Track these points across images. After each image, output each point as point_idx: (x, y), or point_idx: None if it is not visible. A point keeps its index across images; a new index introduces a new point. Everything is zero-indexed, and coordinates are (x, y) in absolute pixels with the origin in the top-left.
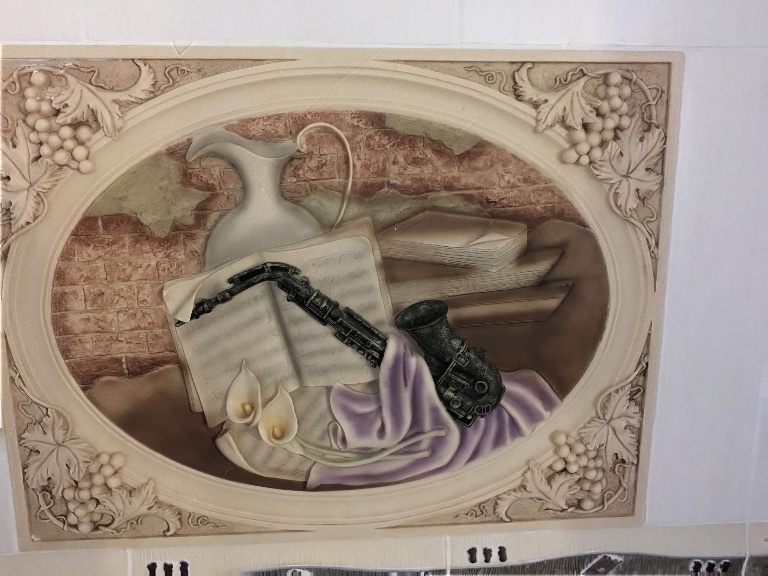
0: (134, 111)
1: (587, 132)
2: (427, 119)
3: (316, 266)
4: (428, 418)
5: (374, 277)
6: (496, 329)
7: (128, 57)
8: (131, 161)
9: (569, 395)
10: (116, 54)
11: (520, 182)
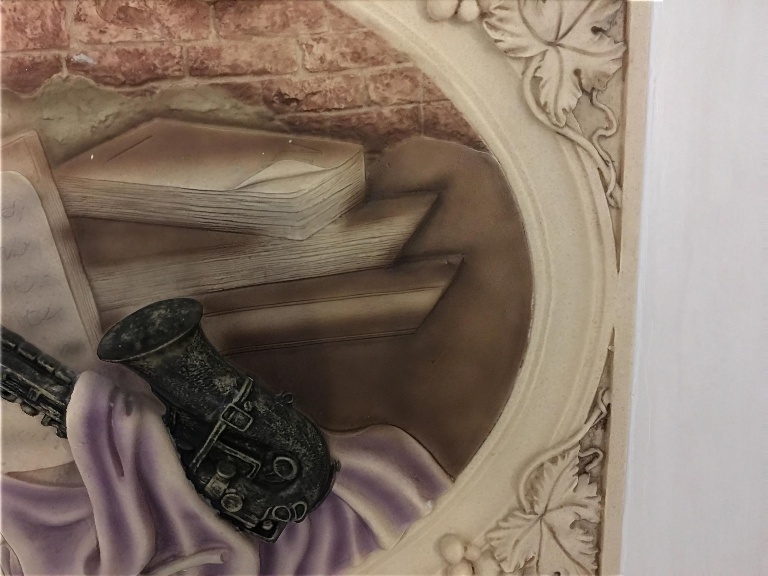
0: None
1: None
2: None
3: None
4: (185, 531)
5: (51, 255)
6: (317, 352)
7: None
8: None
9: (467, 469)
10: None
11: (346, 60)
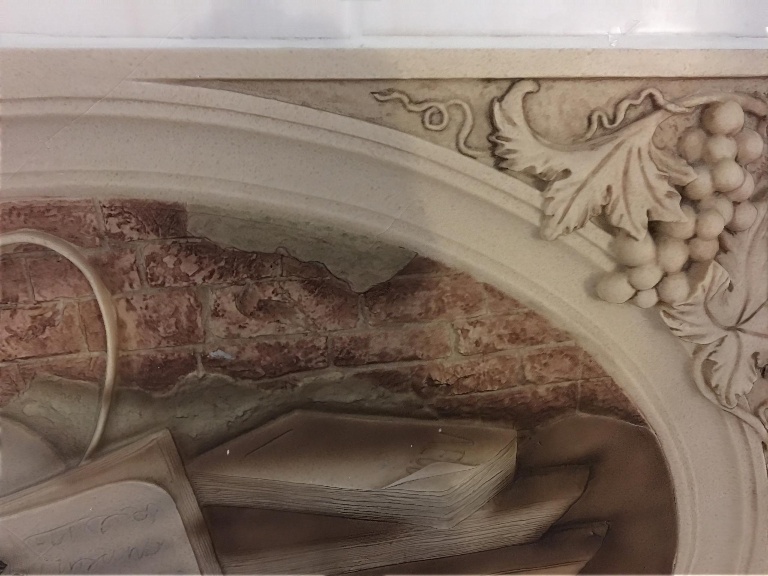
0: None
1: (656, 239)
2: (287, 215)
3: (47, 545)
4: None
5: (185, 552)
6: None
7: None
8: None
9: None
10: None
11: (503, 341)
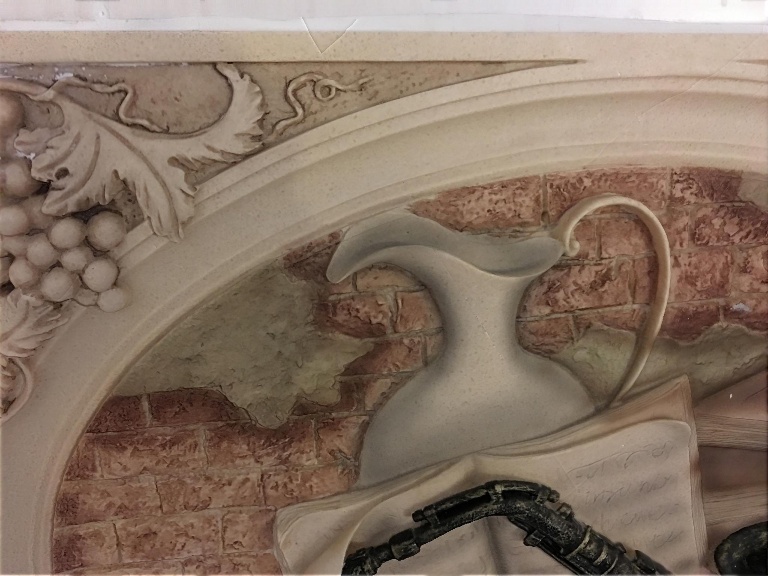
0: (219, 181)
1: None
2: None
3: (583, 478)
4: None
5: (684, 487)
6: None
7: (203, 58)
8: (209, 282)
9: None
10: (175, 52)
11: None
